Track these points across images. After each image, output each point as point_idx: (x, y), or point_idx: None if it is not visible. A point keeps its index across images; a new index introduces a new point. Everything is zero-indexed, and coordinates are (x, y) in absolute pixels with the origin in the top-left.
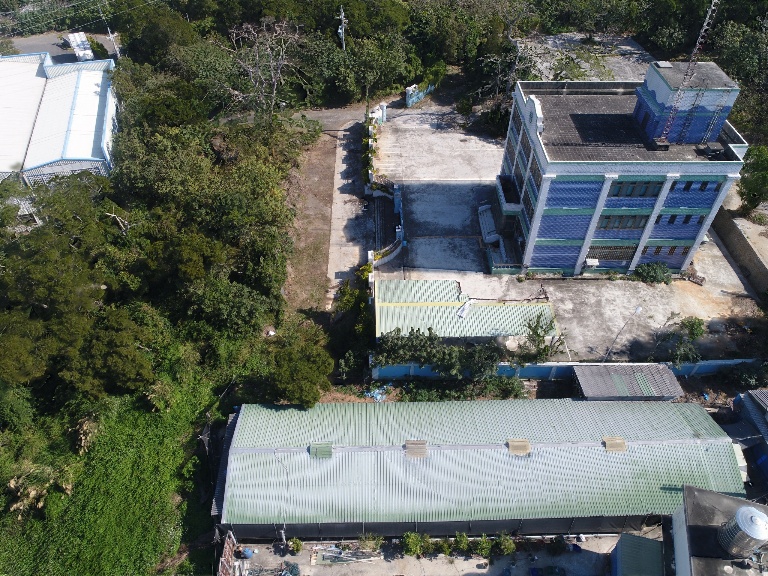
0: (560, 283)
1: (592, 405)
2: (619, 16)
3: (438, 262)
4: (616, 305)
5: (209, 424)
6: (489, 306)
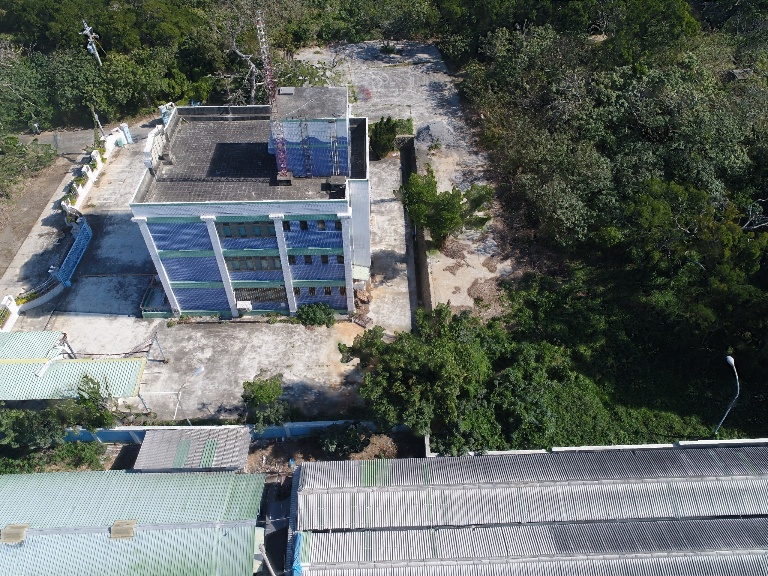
0: (212, 327)
1: (142, 478)
2: (423, 22)
3: (94, 305)
4: (259, 353)
5: None
6: (75, 363)
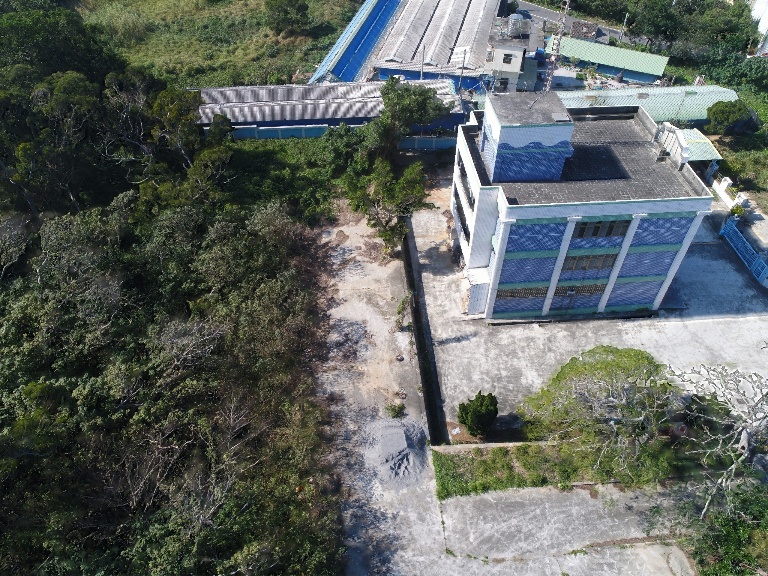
0: None
1: None
2: None
3: None
4: None
5: (760, 125)
6: None
